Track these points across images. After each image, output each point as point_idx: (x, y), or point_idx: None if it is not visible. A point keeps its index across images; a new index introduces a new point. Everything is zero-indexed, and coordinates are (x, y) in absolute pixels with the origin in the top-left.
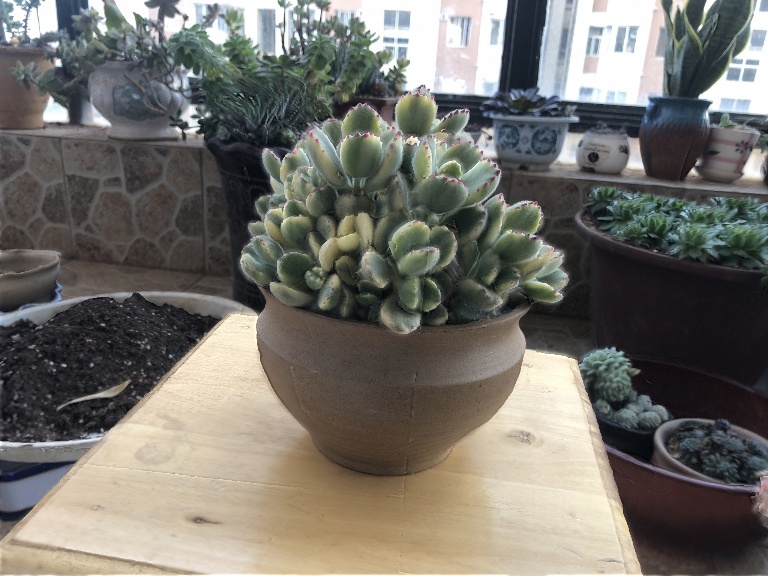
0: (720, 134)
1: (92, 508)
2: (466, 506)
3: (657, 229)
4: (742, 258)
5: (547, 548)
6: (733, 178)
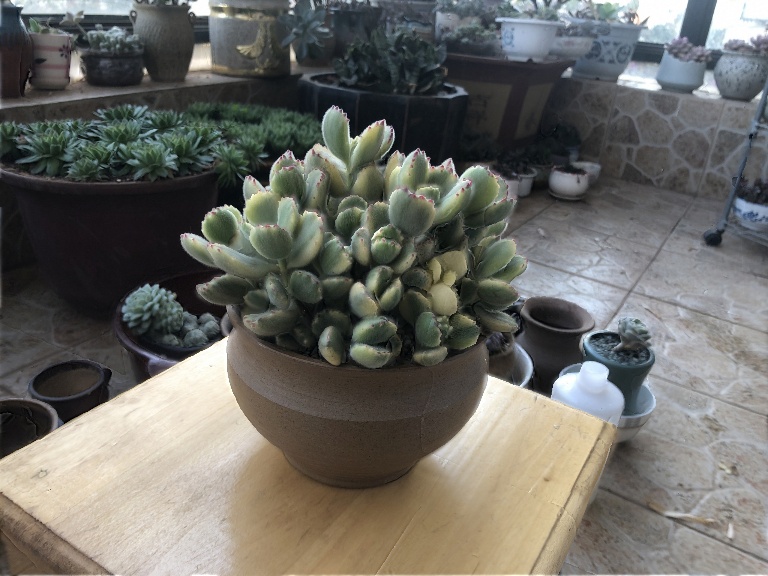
0: (40, 40)
1: None
2: (467, 434)
3: (103, 158)
4: (189, 165)
5: (519, 417)
6: (65, 84)
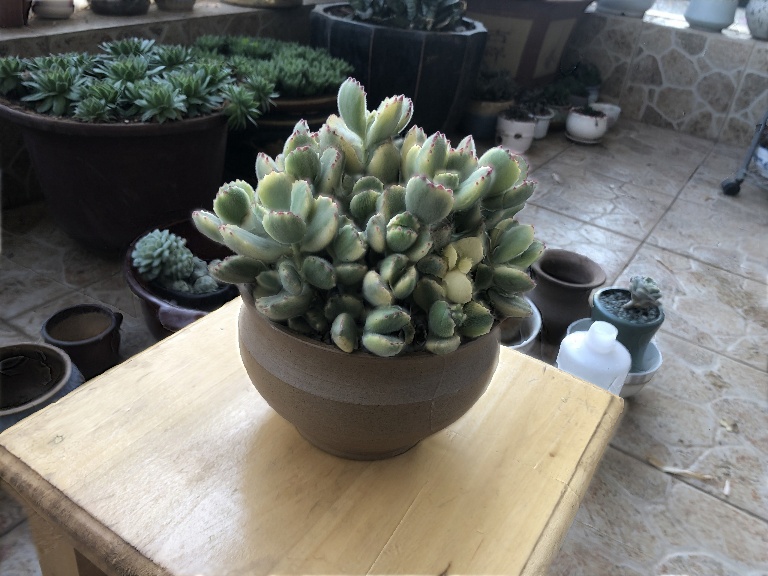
0: None
1: None
2: (475, 405)
3: (110, 97)
4: (198, 105)
5: (527, 389)
6: (69, 12)
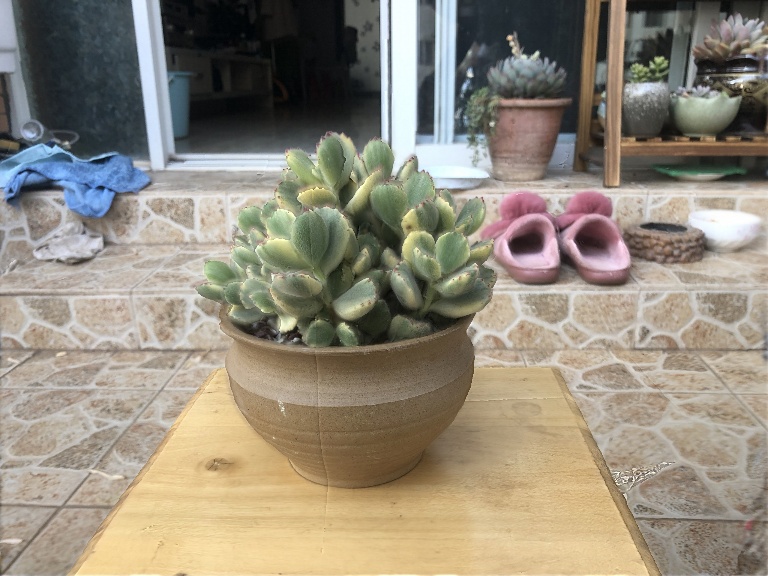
0: None
1: (527, 379)
2: None
3: None
4: None
5: None
6: None
